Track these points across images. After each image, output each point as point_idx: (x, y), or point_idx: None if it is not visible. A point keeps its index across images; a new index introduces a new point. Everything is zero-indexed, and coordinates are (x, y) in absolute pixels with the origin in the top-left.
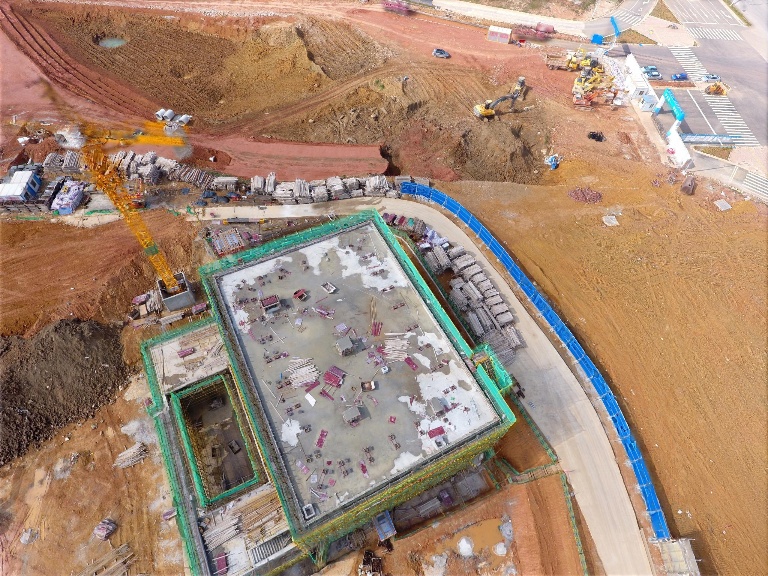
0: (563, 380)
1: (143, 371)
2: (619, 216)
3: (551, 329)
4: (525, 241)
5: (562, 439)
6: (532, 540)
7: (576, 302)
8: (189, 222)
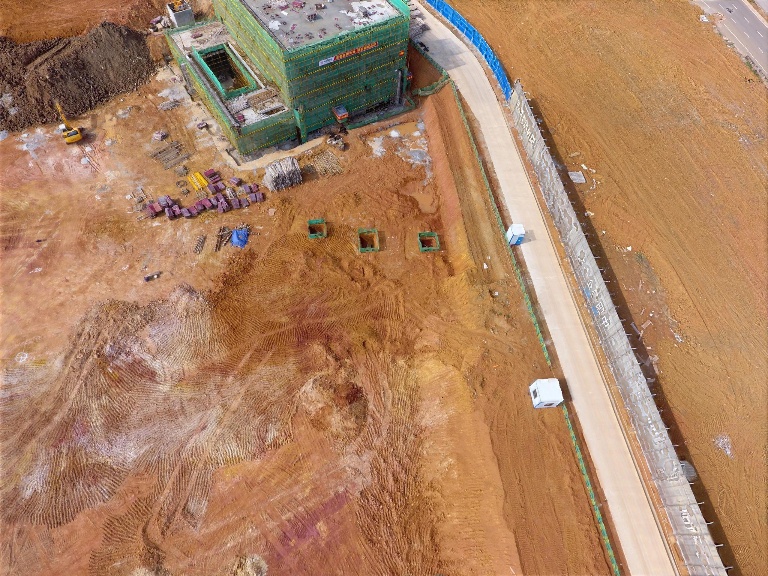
0: (454, 44)
1: (166, 66)
2: None
3: (447, 21)
4: None
5: (452, 68)
6: (434, 119)
7: (465, 7)
8: None
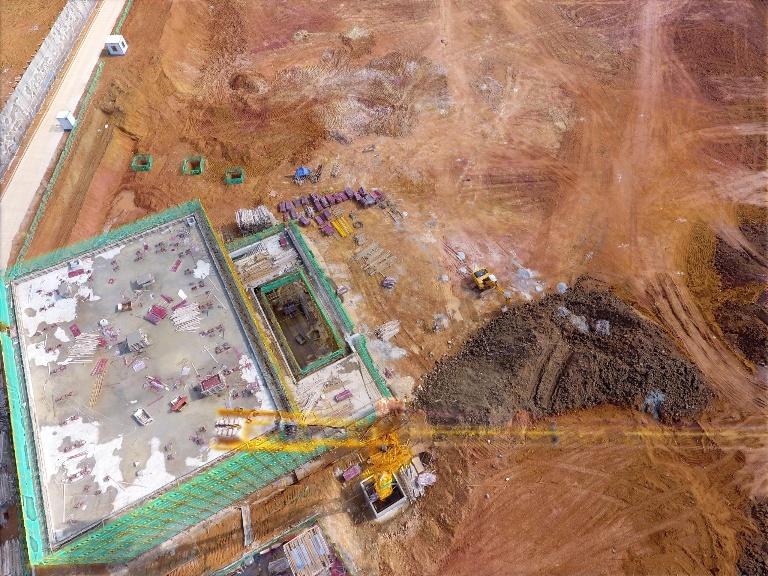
0: None
1: None
2: None
3: None
4: None
5: None
6: None
7: None
8: None
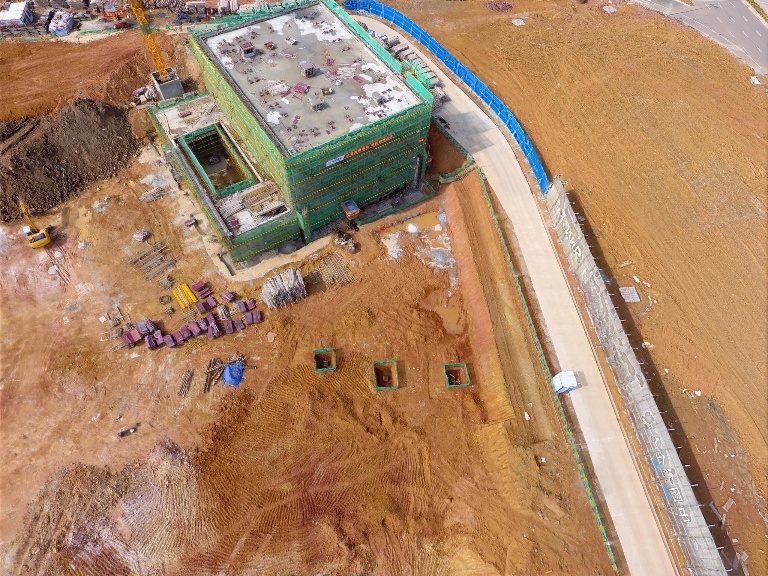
0: (479, 118)
1: (150, 144)
2: (525, 19)
3: (470, 89)
4: (449, 37)
5: (478, 150)
6: (458, 213)
7: (489, 72)
8: (170, 35)
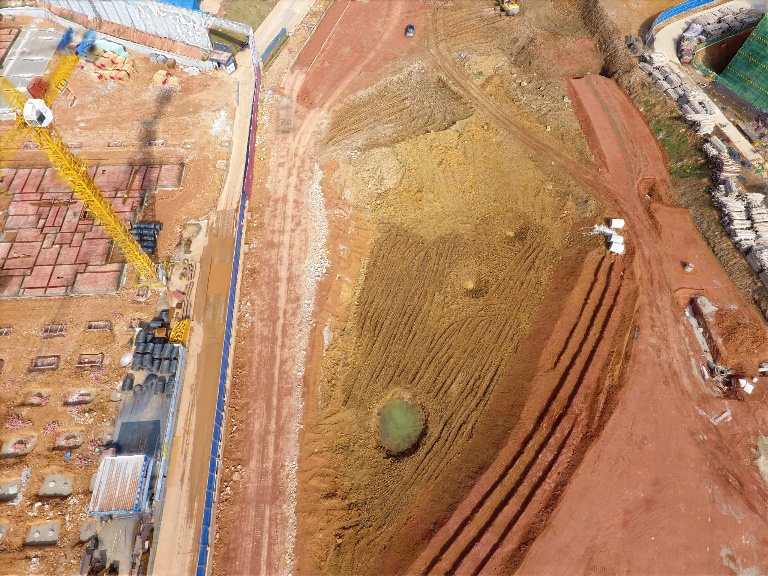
0: None
1: None
2: None
3: None
4: (656, 2)
5: None
6: None
7: None
8: None
